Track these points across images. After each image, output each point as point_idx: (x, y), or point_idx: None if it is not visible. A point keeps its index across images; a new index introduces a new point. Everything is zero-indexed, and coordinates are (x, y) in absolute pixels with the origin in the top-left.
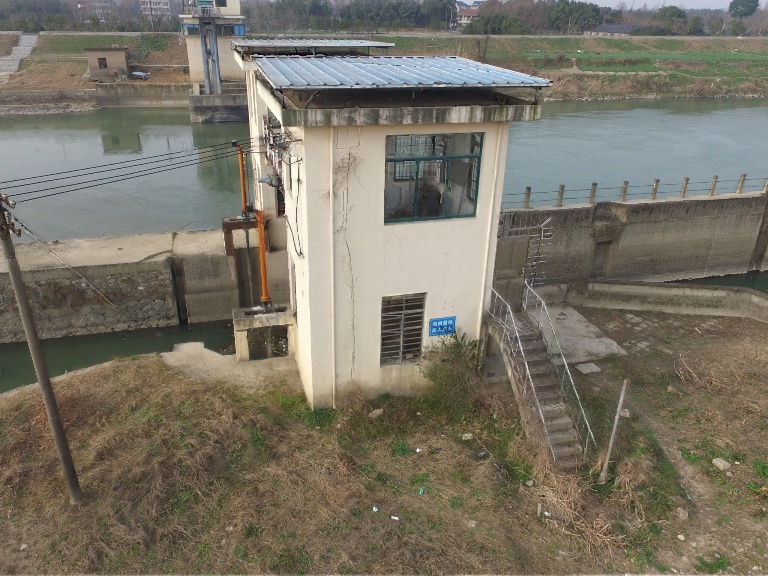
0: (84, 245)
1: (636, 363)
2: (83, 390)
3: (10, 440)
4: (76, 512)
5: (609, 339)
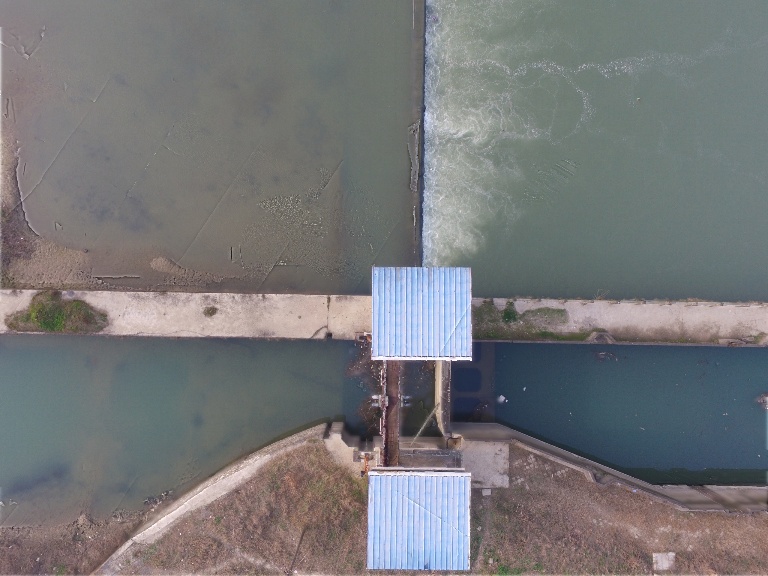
0: (279, 306)
1: (508, 493)
2: (298, 462)
3: (280, 486)
4: (305, 532)
5: (507, 477)
